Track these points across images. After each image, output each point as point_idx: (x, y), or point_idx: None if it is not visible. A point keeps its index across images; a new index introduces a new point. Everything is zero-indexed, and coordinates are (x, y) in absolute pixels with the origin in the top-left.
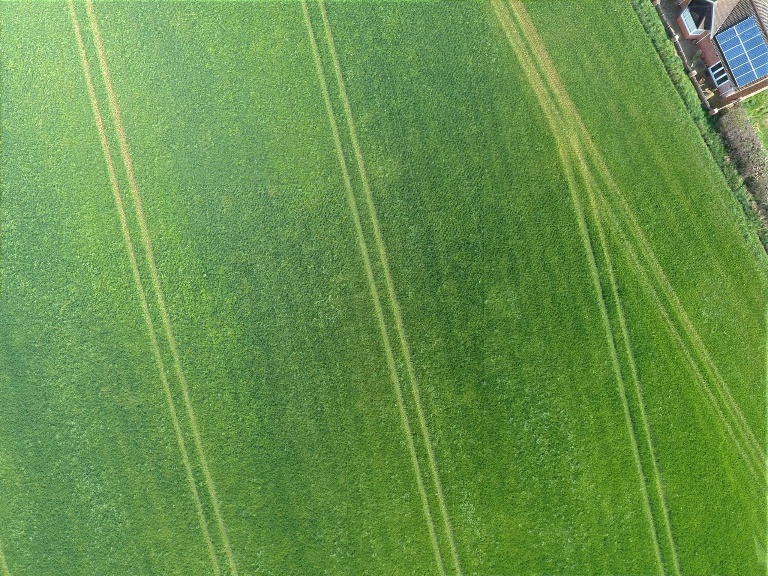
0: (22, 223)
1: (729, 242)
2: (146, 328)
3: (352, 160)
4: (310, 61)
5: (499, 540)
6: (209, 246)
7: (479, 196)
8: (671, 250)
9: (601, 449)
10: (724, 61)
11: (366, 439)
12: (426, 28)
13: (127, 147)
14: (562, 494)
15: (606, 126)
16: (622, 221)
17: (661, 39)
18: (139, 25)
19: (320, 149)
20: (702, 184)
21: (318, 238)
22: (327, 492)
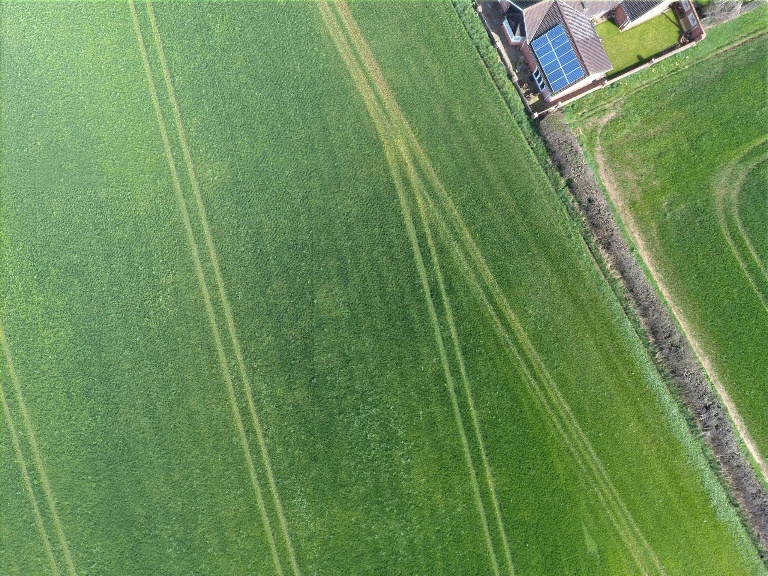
0: None
1: (554, 242)
2: None
3: (181, 163)
4: (139, 67)
5: (333, 534)
6: (40, 248)
7: (307, 198)
8: (497, 250)
9: (431, 444)
10: (540, 67)
11: (199, 436)
12: (254, 35)
13: None
14: (394, 488)
15: (432, 130)
16: (449, 222)
17: (484, 45)
18: None
19: (149, 153)
20: (526, 186)
21: (148, 240)
22: (162, 489)
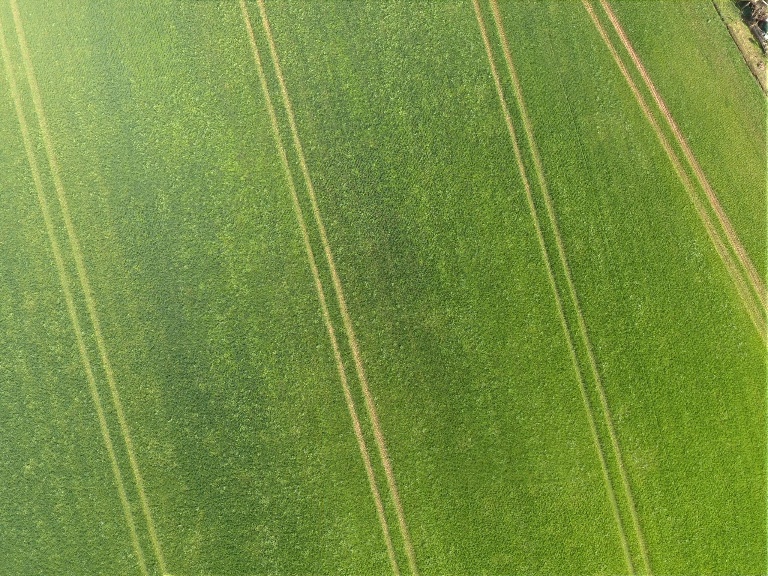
0: (283, 538)
1: None
2: None
3: (610, 454)
4: (566, 354)
5: None
6: (472, 550)
7: (733, 483)
8: None
9: None
10: None
11: None
12: (675, 314)
13: (387, 452)
14: None
15: None
16: None
17: None
18: (394, 324)
19: (579, 444)
20: None
21: (579, 535)
22: None
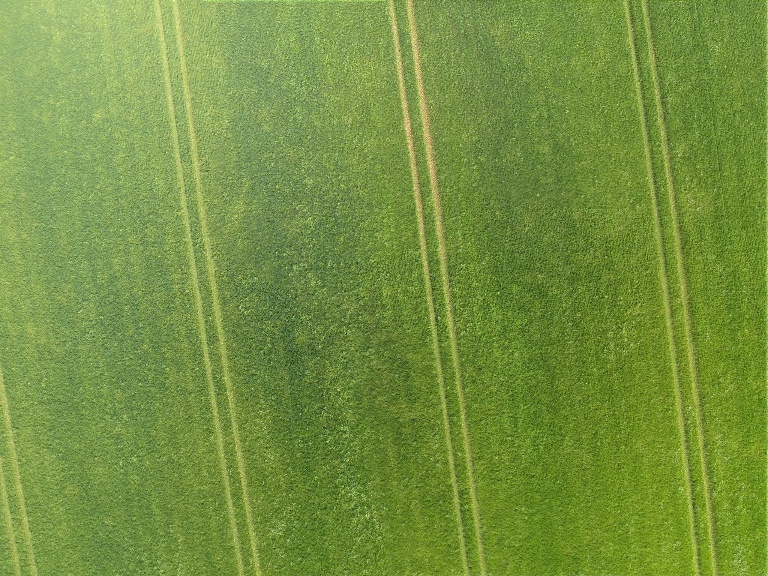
0: (321, 221)
1: None
2: (432, 341)
3: (664, 190)
4: (631, 84)
5: None
6: (506, 264)
7: None
8: None
9: None
10: None
11: (643, 480)
12: (754, 61)
13: (434, 154)
14: None
15: None
16: None
17: None
18: (459, 32)
19: (632, 176)
20: None
21: (619, 267)
22: (595, 530)
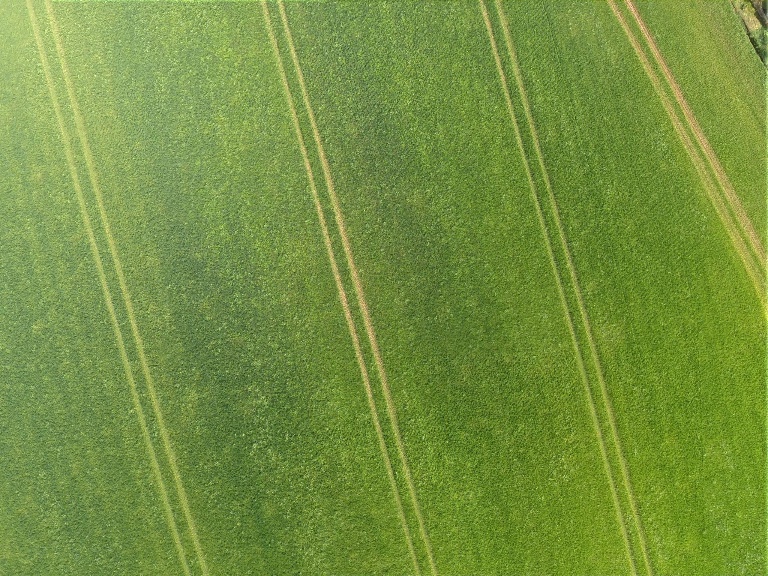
0: (273, 398)
1: None
2: (393, 495)
3: (580, 326)
4: (538, 233)
5: None
6: (450, 413)
7: (695, 356)
8: None
9: None
10: None
11: None
12: (641, 199)
13: (371, 320)
14: None
15: None
16: None
17: None
18: (378, 202)
19: (551, 317)
20: None
21: (551, 402)
22: None
